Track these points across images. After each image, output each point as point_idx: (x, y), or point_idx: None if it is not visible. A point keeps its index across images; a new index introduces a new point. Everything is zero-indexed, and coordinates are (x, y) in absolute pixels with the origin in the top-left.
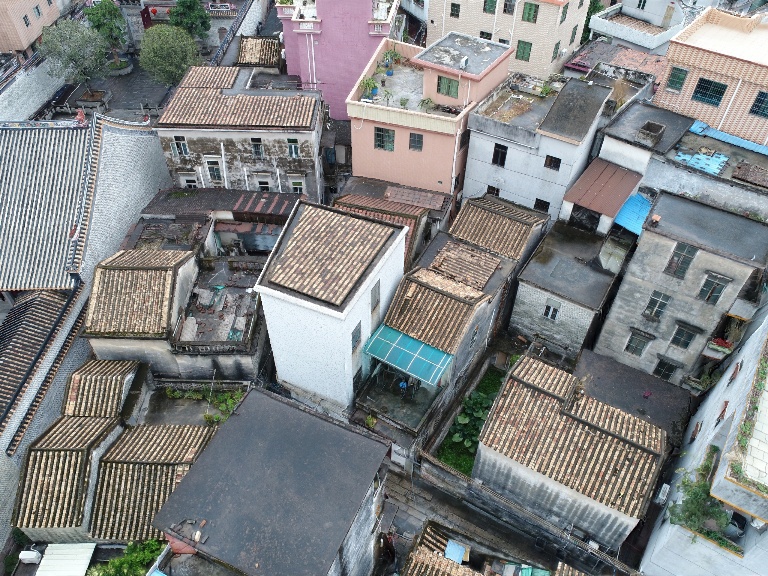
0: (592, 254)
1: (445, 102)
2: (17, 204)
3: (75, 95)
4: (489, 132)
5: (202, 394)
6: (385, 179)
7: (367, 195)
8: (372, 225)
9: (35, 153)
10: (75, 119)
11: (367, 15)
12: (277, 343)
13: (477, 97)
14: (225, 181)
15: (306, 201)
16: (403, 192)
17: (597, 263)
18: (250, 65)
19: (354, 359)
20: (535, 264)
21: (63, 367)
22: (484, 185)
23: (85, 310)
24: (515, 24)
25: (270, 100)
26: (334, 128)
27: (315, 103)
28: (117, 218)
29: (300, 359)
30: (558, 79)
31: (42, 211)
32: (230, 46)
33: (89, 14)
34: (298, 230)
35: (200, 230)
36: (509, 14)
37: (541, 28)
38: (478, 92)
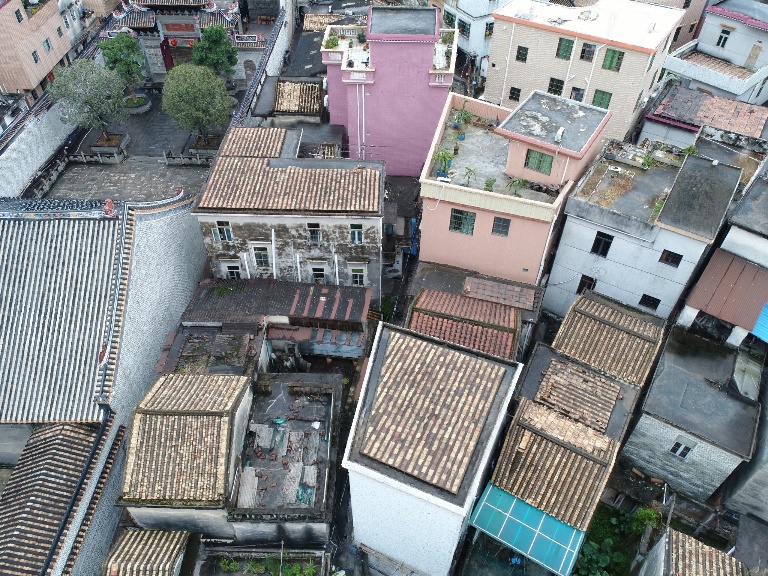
0: (725, 374)
1: (533, 178)
2: (33, 313)
3: (89, 138)
4: (592, 219)
5: (264, 565)
6: (458, 263)
7: (442, 288)
8: (478, 362)
9: (54, 250)
10: (102, 209)
11: (428, 64)
12: (362, 513)
13: (574, 175)
14: (273, 268)
15: (391, 325)
16: (485, 285)
17: (734, 387)
18: (288, 113)
19: (459, 534)
20: (659, 389)
21: (91, 525)
22: (577, 274)
23: (116, 445)
24: (593, 72)
25: (327, 174)
26: (392, 196)
27: (379, 177)
28: (150, 319)
29: (390, 532)
30: (662, 148)
31: (63, 322)
32: (263, 89)
33: (104, 49)
34: (387, 370)
35: (252, 343)
36: (587, 61)
37: (625, 77)
38: (576, 169)
